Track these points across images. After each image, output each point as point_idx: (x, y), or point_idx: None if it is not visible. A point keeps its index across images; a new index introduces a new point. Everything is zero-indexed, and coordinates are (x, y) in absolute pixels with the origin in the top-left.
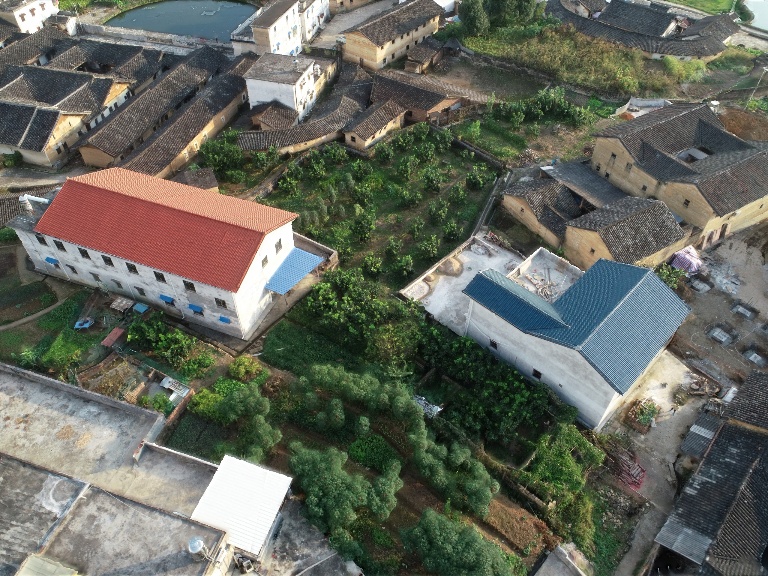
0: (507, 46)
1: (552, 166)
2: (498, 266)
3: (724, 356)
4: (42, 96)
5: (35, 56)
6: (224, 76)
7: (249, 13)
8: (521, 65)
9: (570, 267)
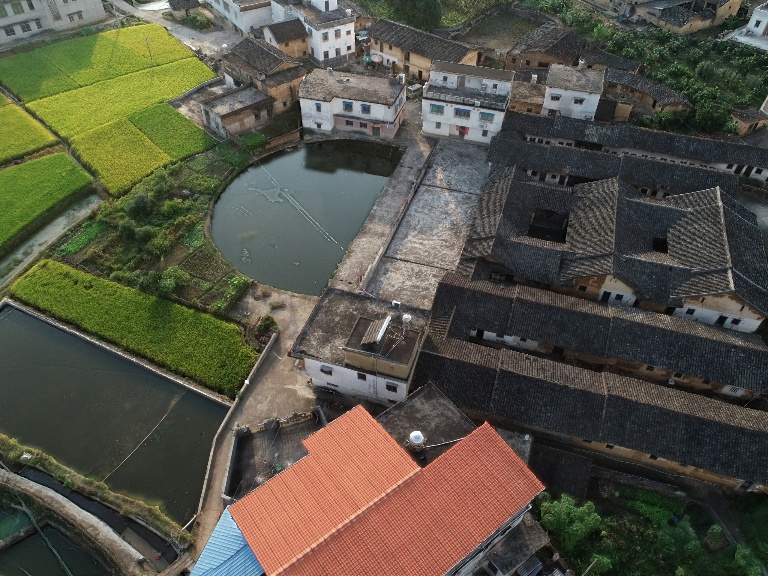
0: (453, 12)
1: (654, 7)
2: (743, 38)
3: (753, 8)
4: (647, 243)
5: (528, 287)
6: (571, 119)
7: (292, 160)
8: (484, 12)
9: (763, 6)
